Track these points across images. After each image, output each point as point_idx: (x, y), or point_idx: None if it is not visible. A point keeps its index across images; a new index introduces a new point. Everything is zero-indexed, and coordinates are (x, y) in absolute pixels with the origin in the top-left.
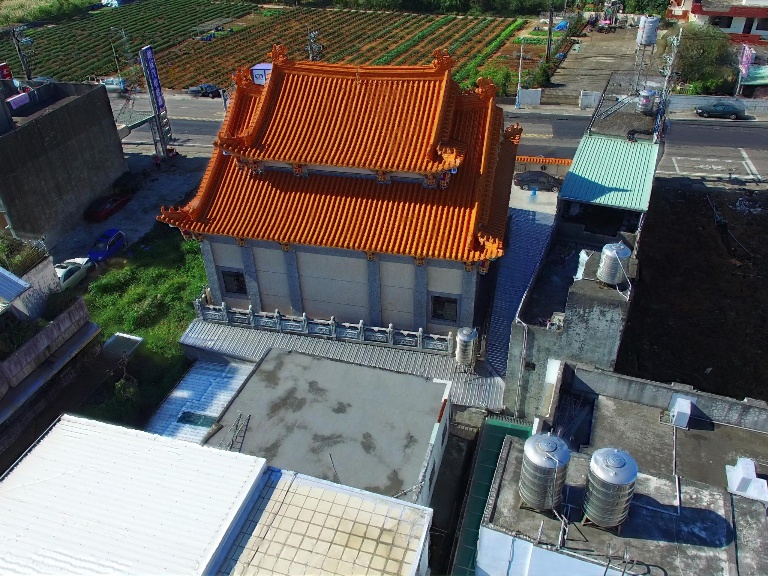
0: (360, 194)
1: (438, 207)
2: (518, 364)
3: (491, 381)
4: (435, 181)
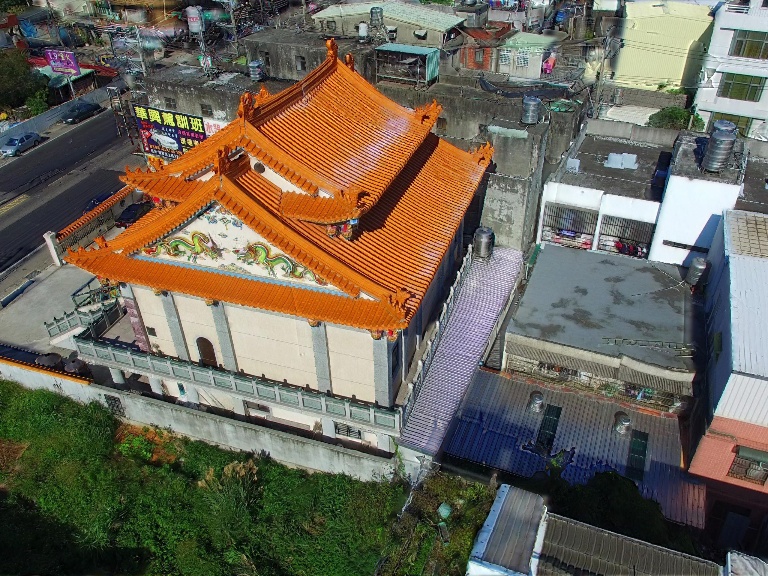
0: (404, 186)
1: (431, 158)
2: None
3: (497, 252)
4: None
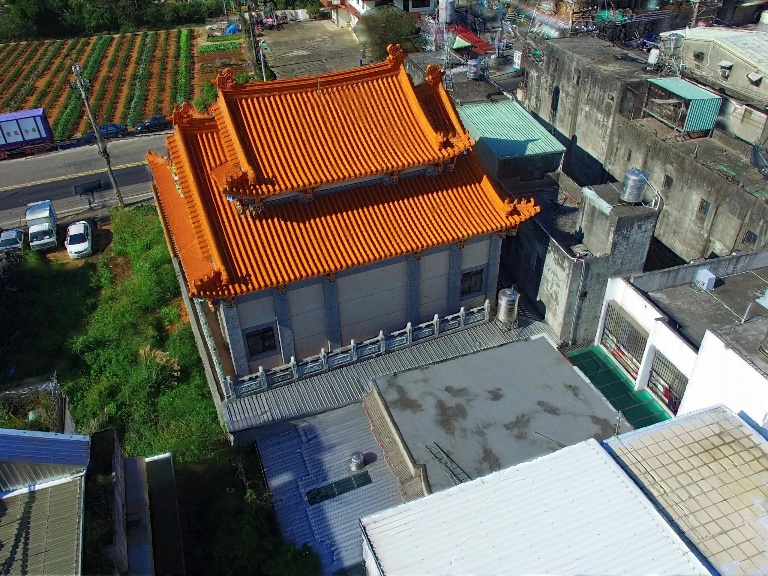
0: (378, 200)
1: (452, 190)
2: (575, 298)
3: (534, 327)
4: (443, 167)
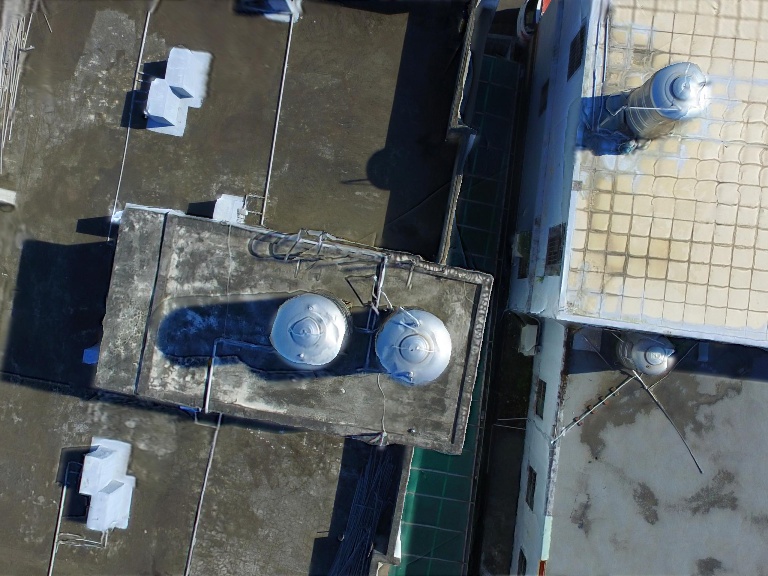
0: None
1: None
2: None
3: None
4: None
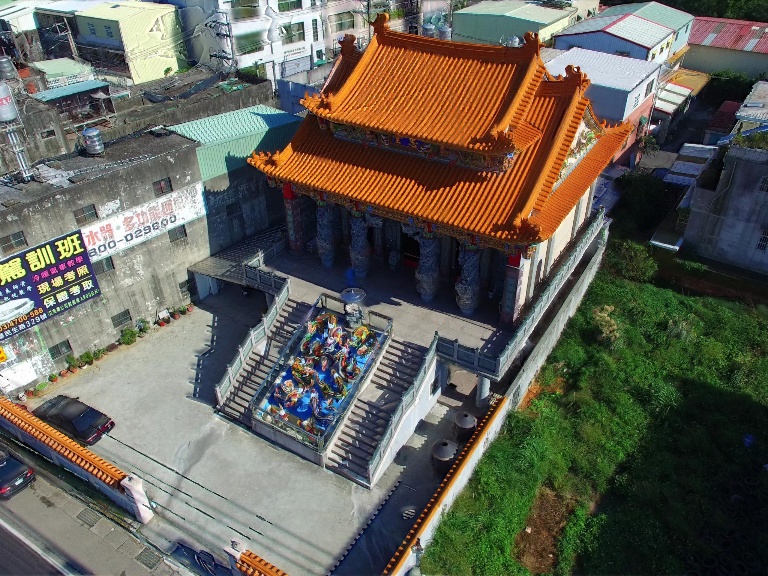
0: None
1: None
2: None
3: None
4: None
